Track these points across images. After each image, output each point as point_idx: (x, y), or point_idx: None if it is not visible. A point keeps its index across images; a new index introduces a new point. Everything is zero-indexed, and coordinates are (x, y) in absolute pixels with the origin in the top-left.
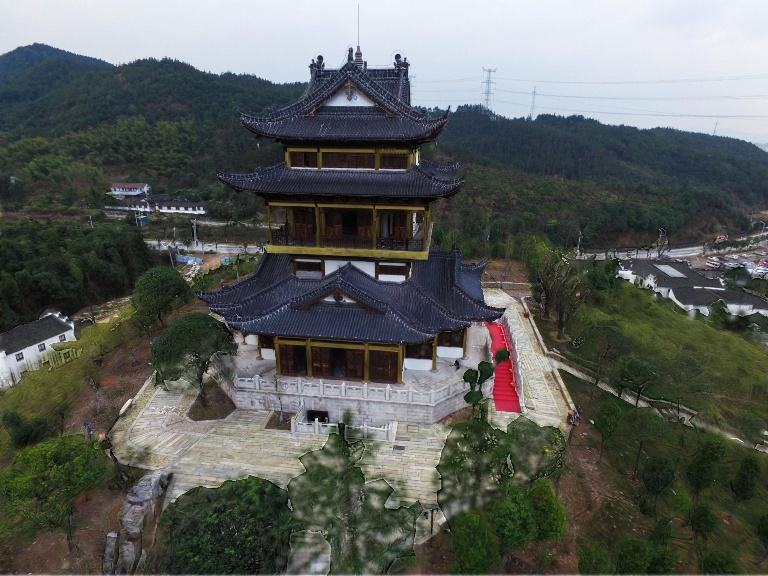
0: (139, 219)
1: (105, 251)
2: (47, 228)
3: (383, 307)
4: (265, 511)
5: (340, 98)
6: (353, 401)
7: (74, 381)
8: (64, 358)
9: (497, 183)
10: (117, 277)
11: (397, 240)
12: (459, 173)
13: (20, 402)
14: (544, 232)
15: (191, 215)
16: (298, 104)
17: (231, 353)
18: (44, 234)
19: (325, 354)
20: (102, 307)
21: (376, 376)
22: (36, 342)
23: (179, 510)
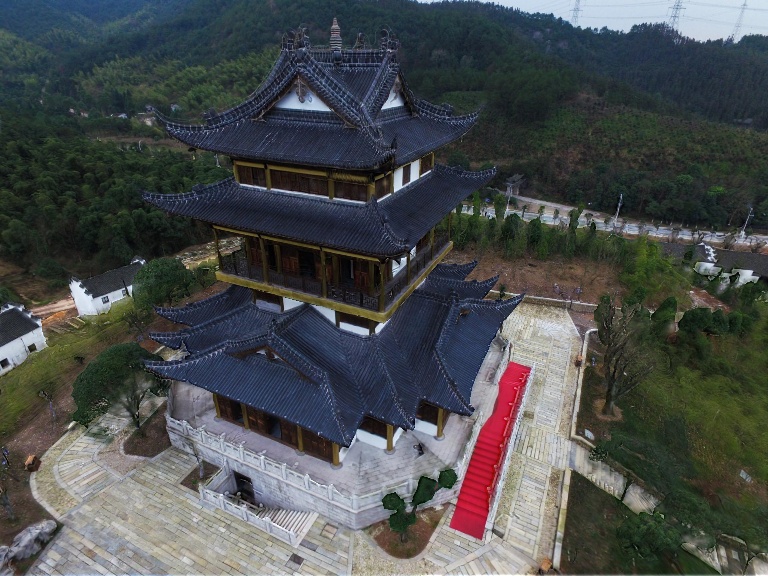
0: None
1: None
2: (178, 163)
3: (318, 376)
4: None
5: (293, 98)
6: (272, 478)
7: (96, 354)
8: None
9: (653, 133)
10: None
11: (359, 286)
12: (606, 118)
13: (17, 385)
14: (701, 202)
15: None
16: (245, 105)
17: (158, 394)
18: (174, 169)
19: (259, 411)
20: (202, 248)
21: (311, 449)
22: (120, 288)
23: None
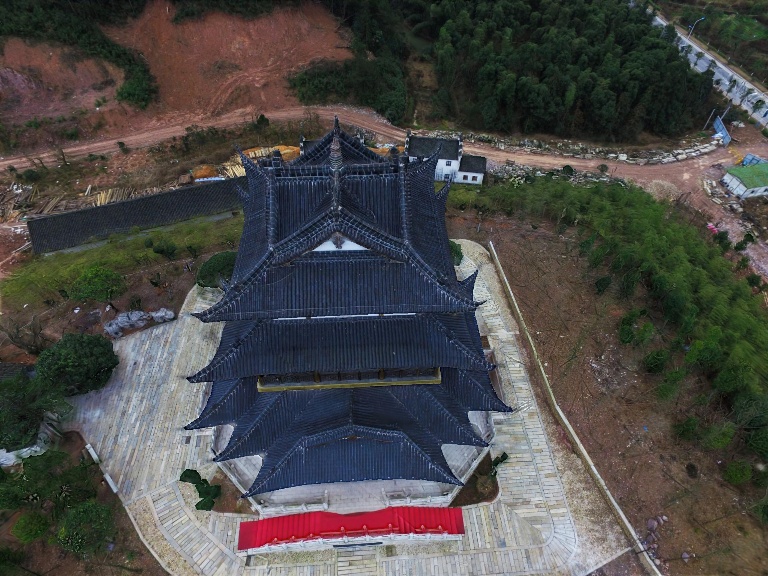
0: None
1: (628, 82)
2: (638, 23)
3: None
4: (52, 373)
5: None
6: None
7: None
8: (445, 177)
9: None
10: (602, 118)
11: None
12: None
13: None
14: None
15: None
16: None
17: None
18: (625, 30)
19: None
20: (555, 142)
21: None
22: None
23: (62, 339)
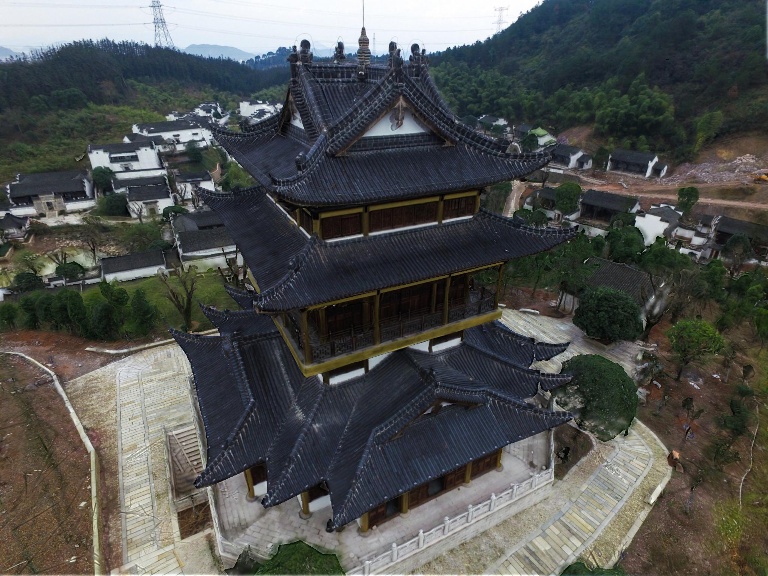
0: None
1: None
2: None
3: None
4: None
5: None
6: None
7: None
8: None
9: None
10: None
11: None
12: None
13: None
14: None
15: None
16: None
17: None
18: None
19: None
20: None
21: None
22: None
23: None
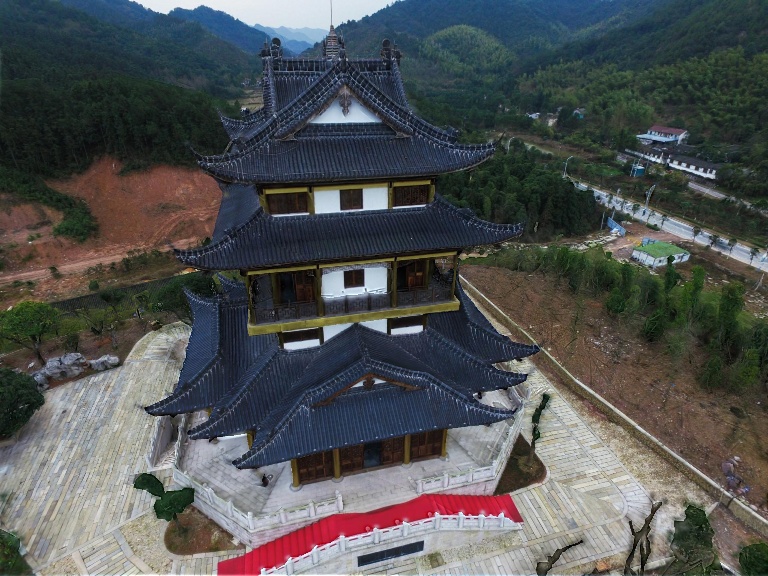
0: (635, 169)
1: (531, 195)
2: None
3: None
4: None
5: None
6: None
7: None
8: None
9: None
10: None
11: None
12: None
13: None
14: None
15: (698, 177)
16: None
17: None
18: (516, 167)
19: None
20: None
21: None
22: None
23: None
